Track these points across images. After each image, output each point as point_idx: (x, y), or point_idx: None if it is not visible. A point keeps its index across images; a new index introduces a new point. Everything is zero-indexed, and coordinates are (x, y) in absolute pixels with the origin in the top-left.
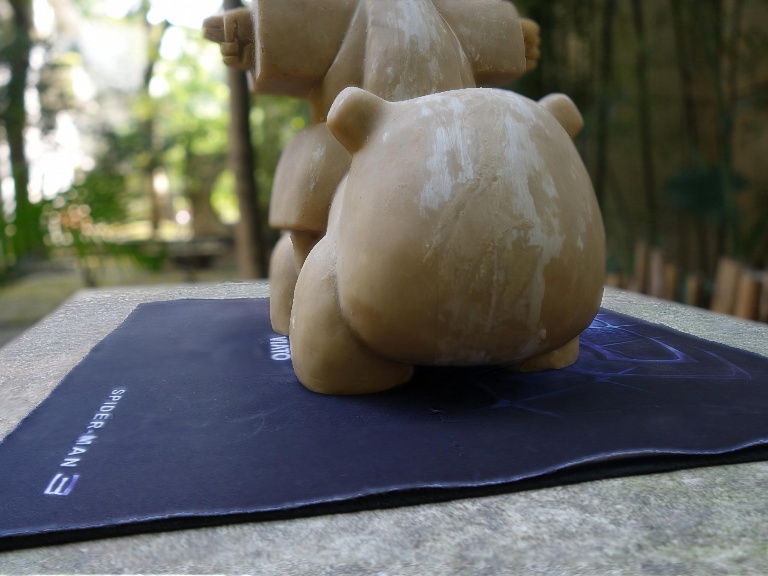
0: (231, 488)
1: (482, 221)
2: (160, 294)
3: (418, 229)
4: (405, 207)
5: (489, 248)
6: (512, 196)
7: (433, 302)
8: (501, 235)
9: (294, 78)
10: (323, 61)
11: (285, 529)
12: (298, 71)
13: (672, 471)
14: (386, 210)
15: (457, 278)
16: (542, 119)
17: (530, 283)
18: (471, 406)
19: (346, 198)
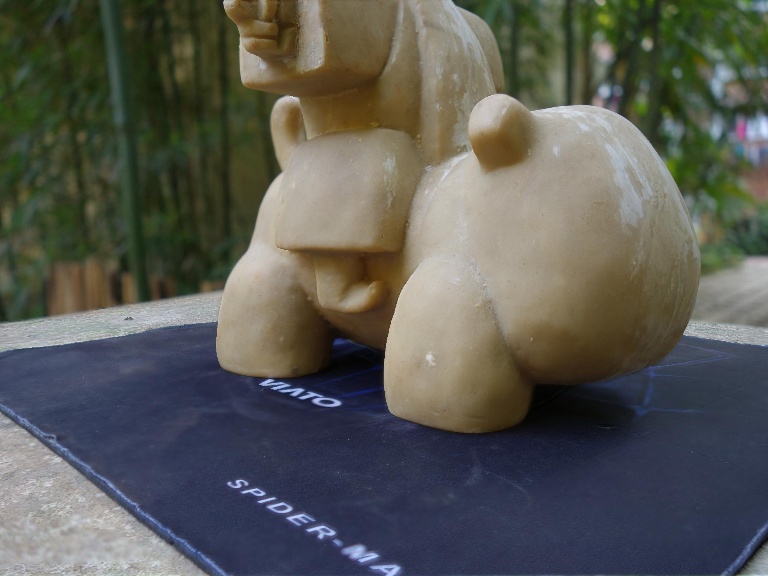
0: (655, 552)
1: (668, 237)
2: None
3: (624, 247)
4: (607, 225)
5: (676, 262)
6: (678, 212)
7: (634, 319)
8: (681, 249)
9: (350, 75)
10: (379, 59)
11: (764, 575)
12: (359, 67)
13: None
14: (585, 228)
15: (656, 293)
16: None
17: (693, 293)
18: (623, 417)
19: (503, 215)
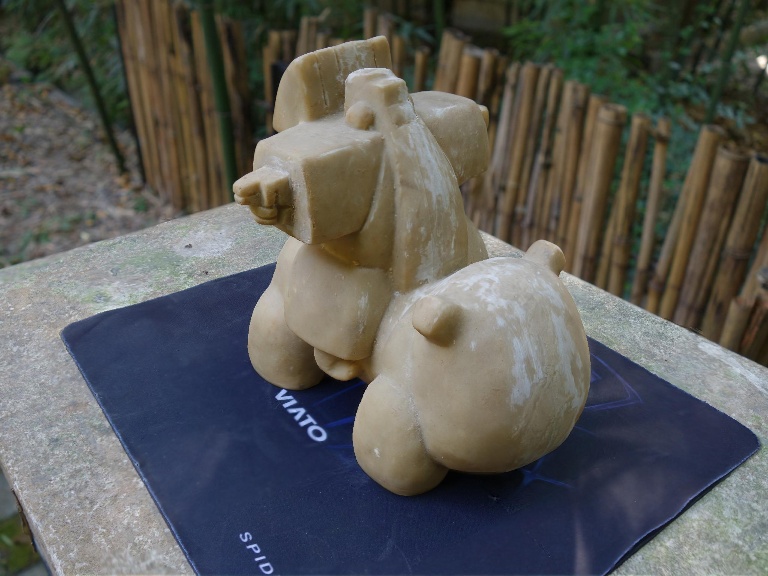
0: None
1: (549, 406)
2: (38, 287)
3: (509, 419)
4: (499, 405)
5: (552, 421)
6: (564, 382)
7: (513, 456)
8: (559, 410)
9: None
10: (360, 220)
11: None
12: (341, 234)
13: (657, 535)
14: (483, 406)
15: (532, 442)
16: (565, 300)
17: None
18: (511, 485)
19: (432, 379)
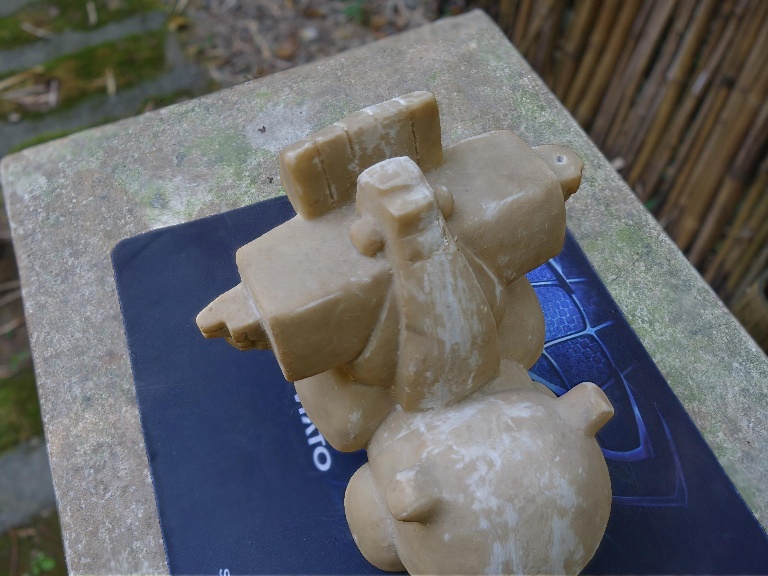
0: None
1: None
2: (102, 171)
3: None
4: None
5: None
6: None
7: None
8: None
9: None
10: (352, 354)
11: None
12: None
13: None
14: None
15: None
16: (582, 492)
17: None
18: None
19: (405, 531)
